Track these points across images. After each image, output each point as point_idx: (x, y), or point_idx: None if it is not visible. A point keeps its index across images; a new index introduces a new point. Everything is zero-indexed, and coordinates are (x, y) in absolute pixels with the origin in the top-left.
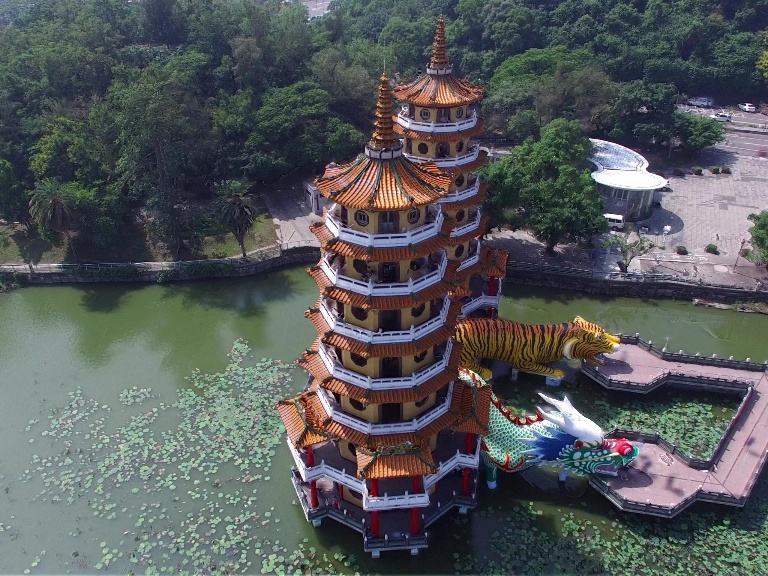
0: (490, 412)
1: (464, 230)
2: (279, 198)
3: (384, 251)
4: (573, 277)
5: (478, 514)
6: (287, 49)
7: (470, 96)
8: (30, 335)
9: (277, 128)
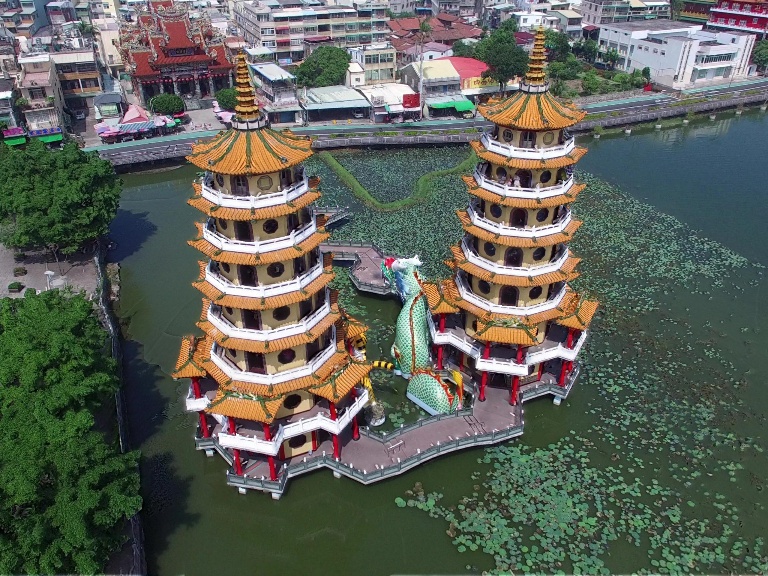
0: None
1: None
2: None
3: None
4: None
5: None
6: None
7: None
8: None
9: None
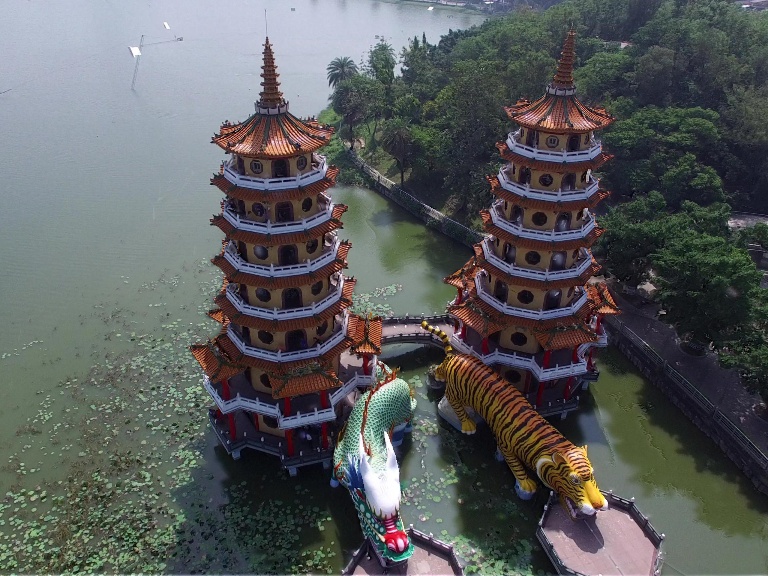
0: (356, 417)
1: (525, 273)
2: (597, 214)
3: (226, 182)
4: (745, 451)
5: (296, 484)
6: (727, 71)
7: (561, 125)
8: (359, 224)
9: (617, 142)
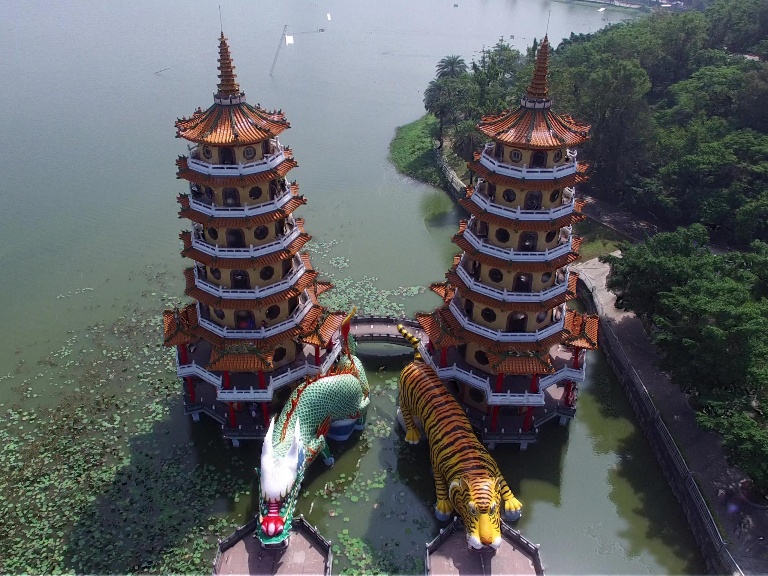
0: (289, 403)
1: (484, 290)
2: None
3: None
4: (705, 527)
5: (234, 455)
6: None
7: (520, 139)
8: None
9: (695, 166)
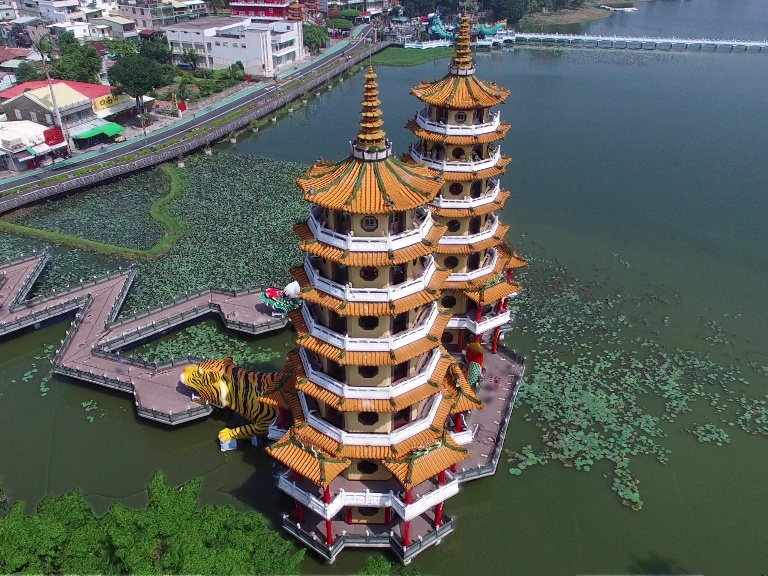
0: None
1: None
2: None
3: None
4: None
5: None
6: None
7: None
8: None
9: None
